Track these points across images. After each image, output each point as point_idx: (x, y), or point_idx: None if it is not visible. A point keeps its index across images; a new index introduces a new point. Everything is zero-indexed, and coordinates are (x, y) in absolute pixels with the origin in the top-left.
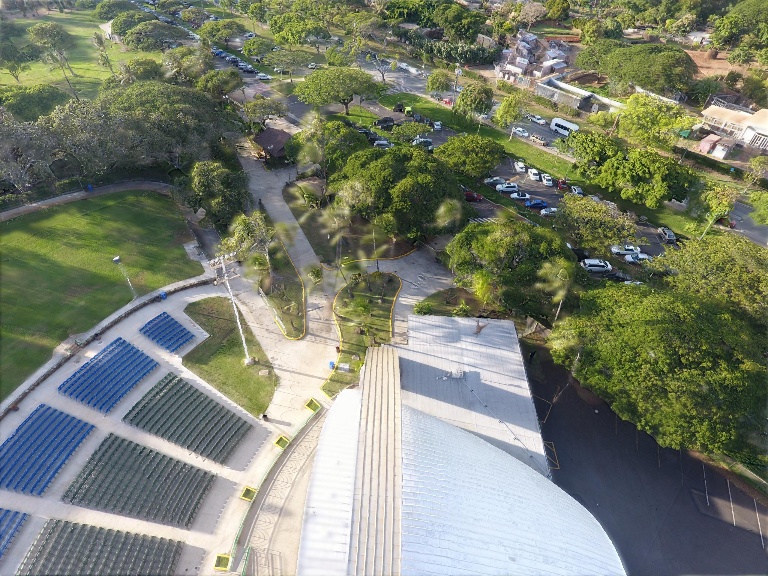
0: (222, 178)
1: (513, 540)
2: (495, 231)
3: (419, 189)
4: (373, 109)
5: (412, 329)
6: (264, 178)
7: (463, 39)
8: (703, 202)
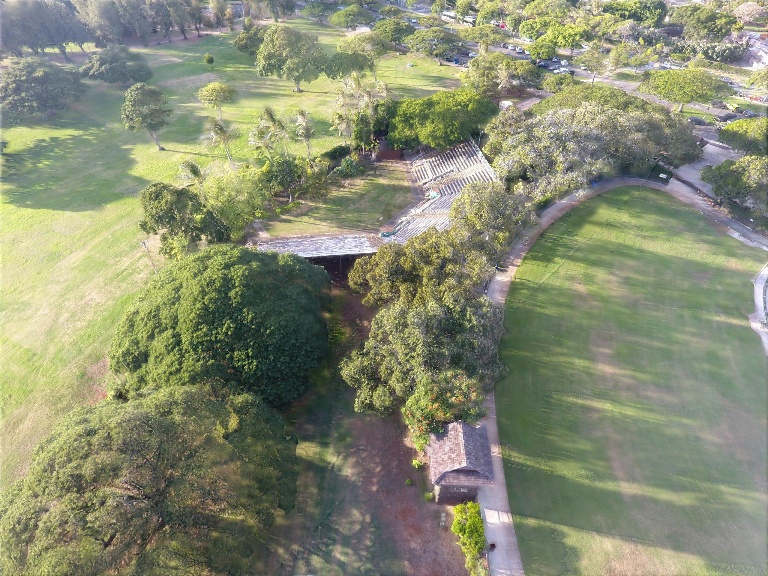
0: None
1: None
2: None
3: None
4: (695, 106)
5: None
6: (689, 172)
7: (704, 38)
8: None
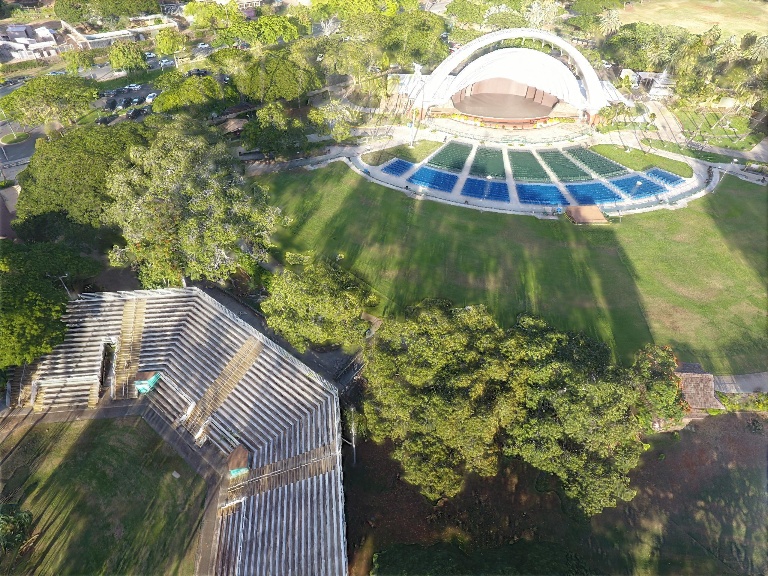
0: None
1: None
2: (350, 47)
3: None
4: None
5: (398, 92)
6: None
7: None
8: (302, 26)
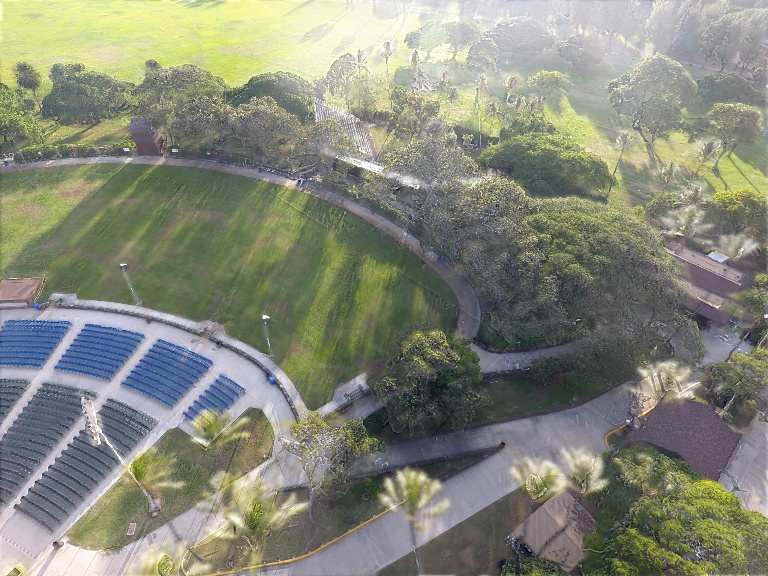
0: None
1: None
2: None
3: None
4: None
5: None
6: (579, 437)
7: None
8: None
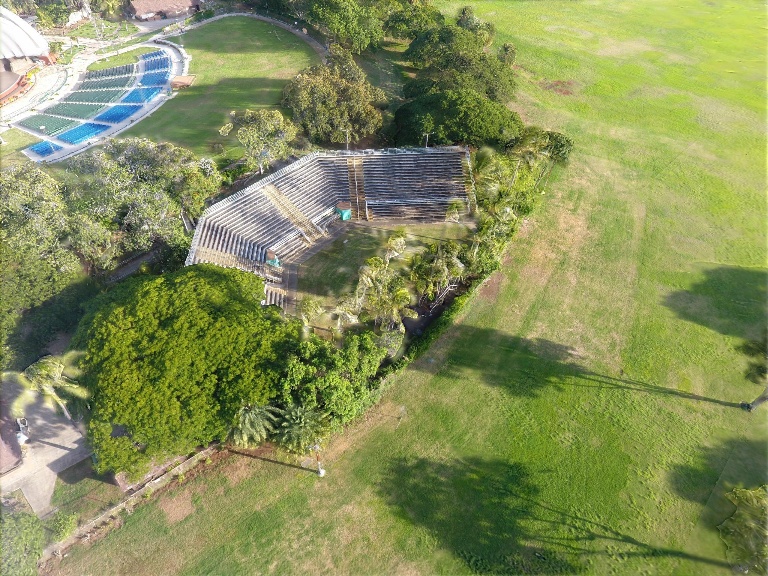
0: None
1: None
2: None
3: None
4: None
5: None
6: None
7: None
8: None
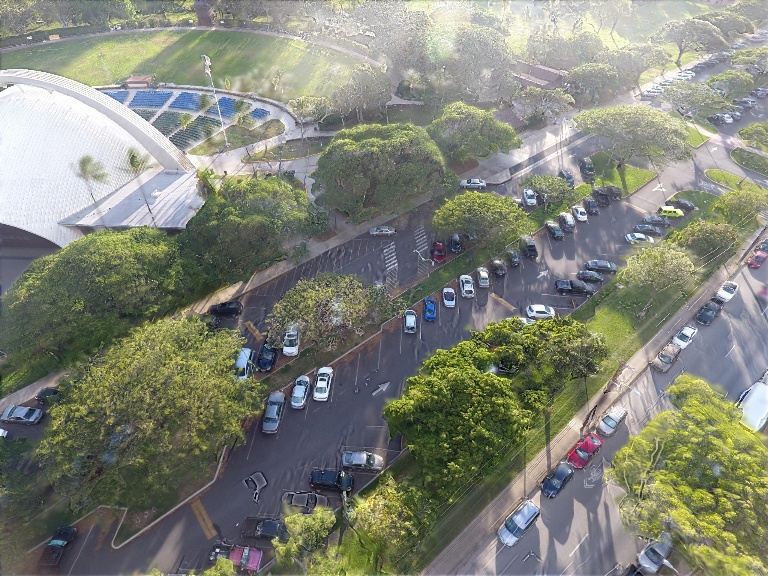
0: (356, 77)
1: (1, 145)
2: None
3: (340, 150)
4: (657, 186)
5: None
6: None
7: None
8: None
